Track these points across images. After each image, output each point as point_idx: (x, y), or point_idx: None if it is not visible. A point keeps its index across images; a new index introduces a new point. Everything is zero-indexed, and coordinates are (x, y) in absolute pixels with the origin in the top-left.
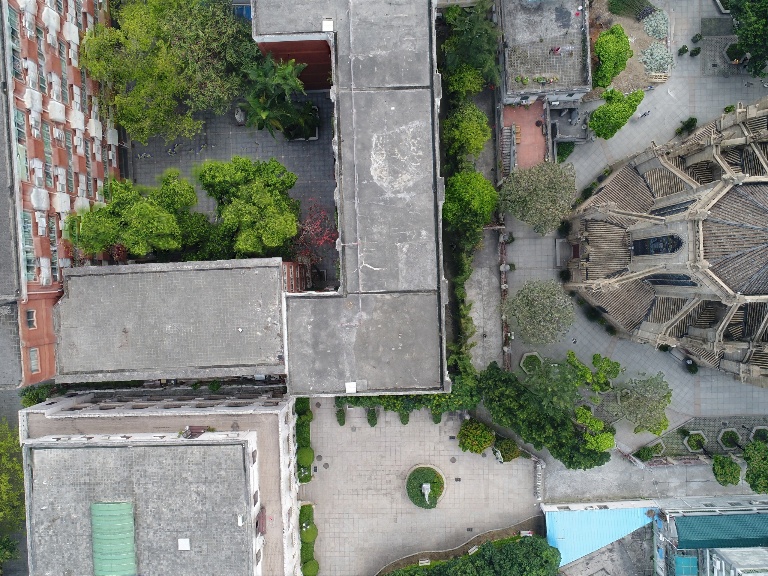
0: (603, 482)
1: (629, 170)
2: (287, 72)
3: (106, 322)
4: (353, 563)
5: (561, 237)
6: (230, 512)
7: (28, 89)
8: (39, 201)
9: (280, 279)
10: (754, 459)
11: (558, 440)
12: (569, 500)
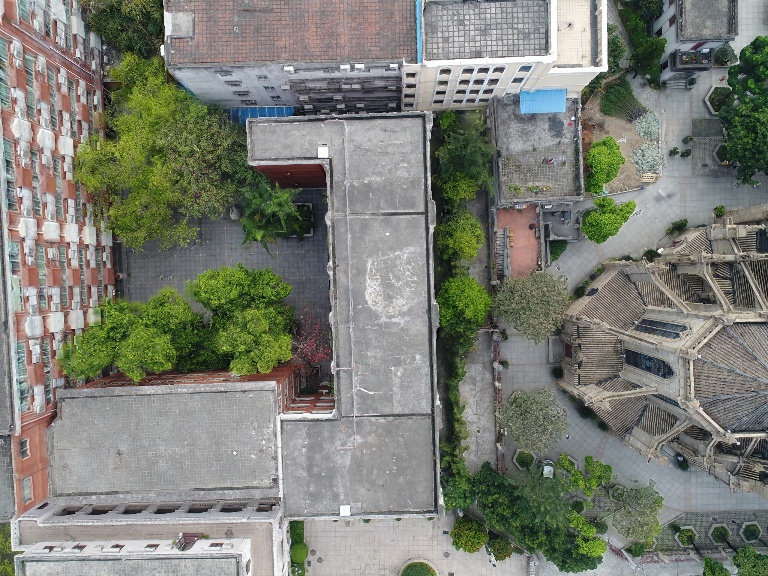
0: None
1: (621, 277)
2: (282, 200)
3: (100, 444)
4: None
5: (554, 334)
6: None
7: (23, 218)
8: (33, 329)
9: (275, 403)
10: (744, 566)
11: (551, 544)
12: None
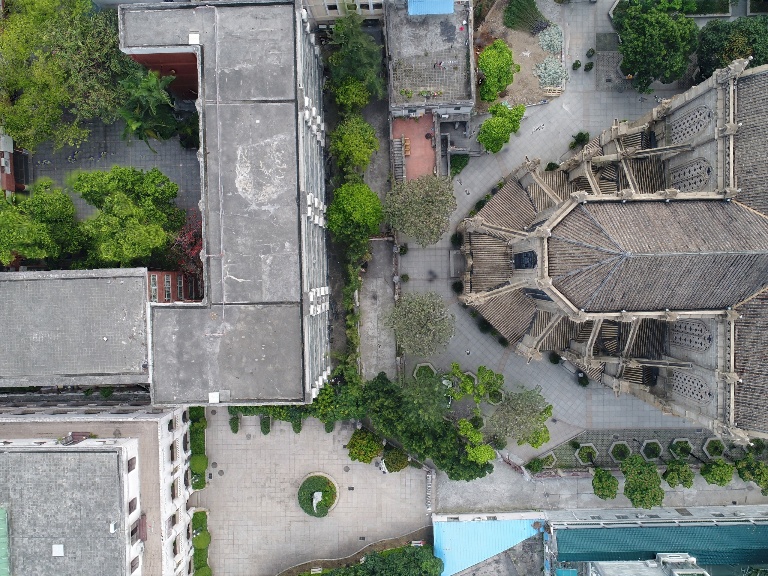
0: (495, 493)
1: (513, 184)
2: (151, 84)
3: None
4: (247, 570)
5: (455, 249)
6: (104, 519)
7: None
8: None
9: (145, 289)
10: (630, 473)
11: (440, 451)
12: (461, 510)
